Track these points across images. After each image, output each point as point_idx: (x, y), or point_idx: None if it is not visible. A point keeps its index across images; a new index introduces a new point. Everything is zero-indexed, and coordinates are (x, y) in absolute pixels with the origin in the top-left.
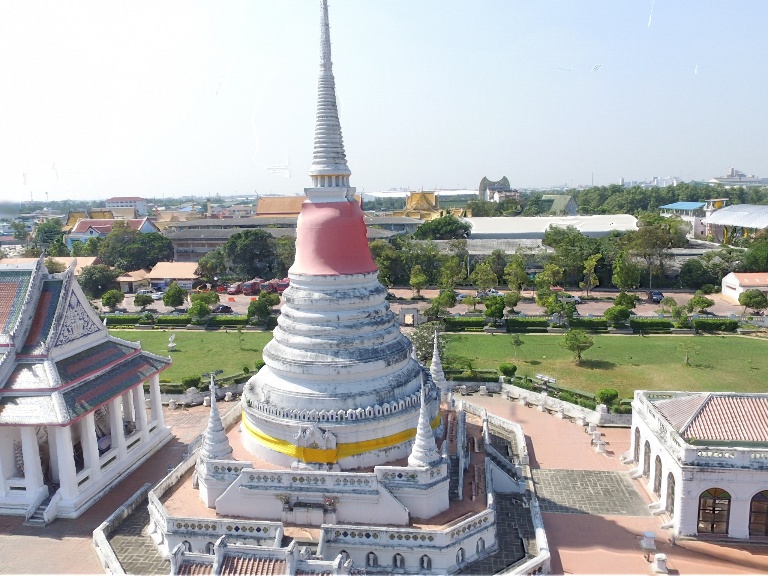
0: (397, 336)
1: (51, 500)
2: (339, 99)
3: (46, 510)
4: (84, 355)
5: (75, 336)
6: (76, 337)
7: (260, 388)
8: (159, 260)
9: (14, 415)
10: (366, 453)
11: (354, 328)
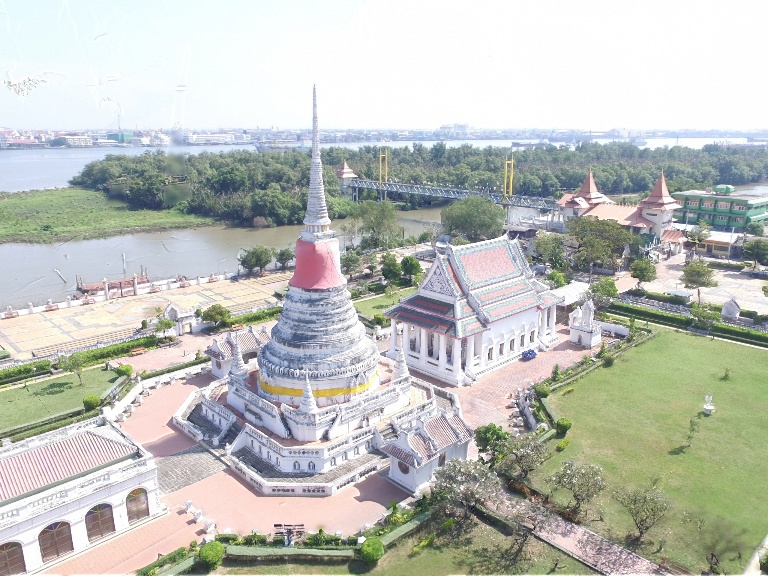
0: None
1: None
2: None
3: None
4: (432, 301)
5: None
6: None
7: None
8: None
9: None
10: None
11: None
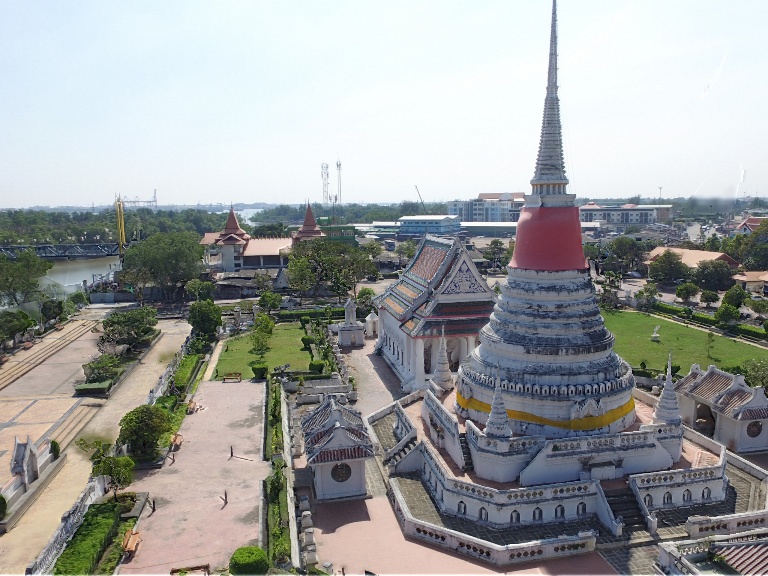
0: (566, 334)
1: (410, 381)
2: None
3: (405, 385)
4: (463, 304)
5: (462, 291)
6: (462, 292)
7: None
8: None
9: None
10: (483, 412)
11: (514, 314)
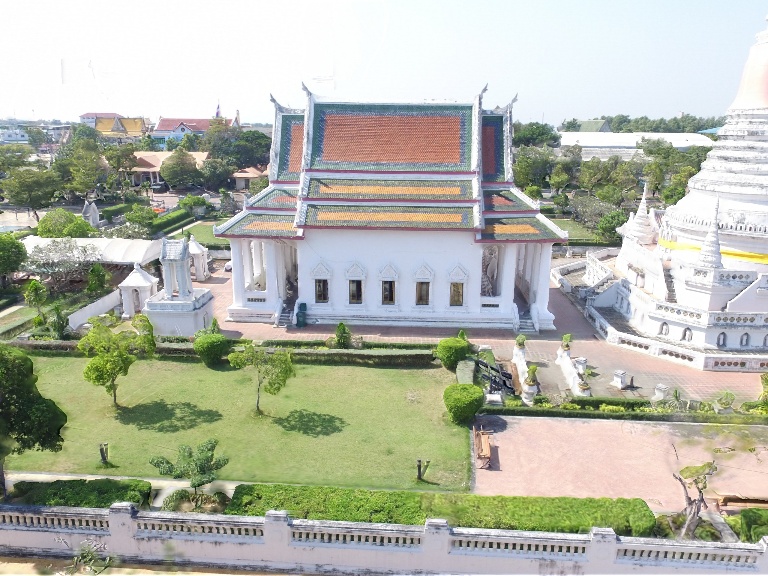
0: None
1: (534, 313)
2: (385, 8)
3: (537, 321)
4: None
5: None
6: None
7: (724, 213)
8: (266, 159)
9: (510, 233)
10: None
11: None
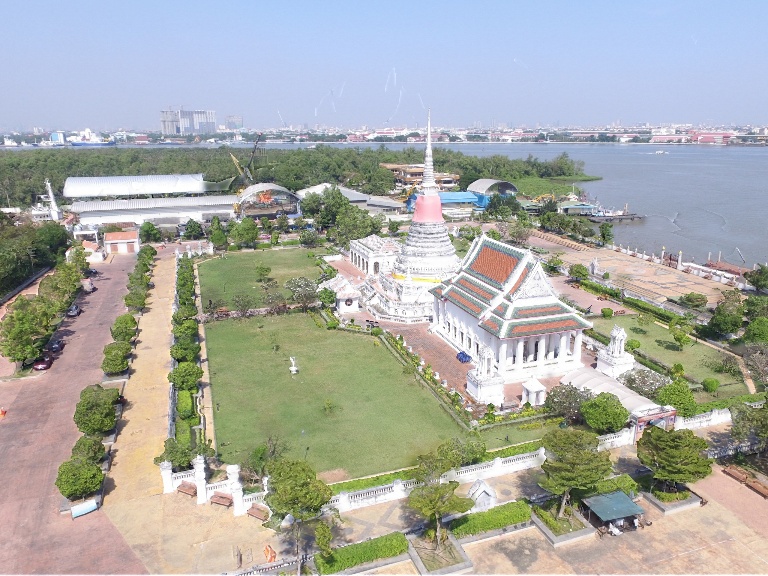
0: None
1: None
2: None
3: None
4: None
5: None
6: None
7: None
8: None
9: None
10: None
11: None
